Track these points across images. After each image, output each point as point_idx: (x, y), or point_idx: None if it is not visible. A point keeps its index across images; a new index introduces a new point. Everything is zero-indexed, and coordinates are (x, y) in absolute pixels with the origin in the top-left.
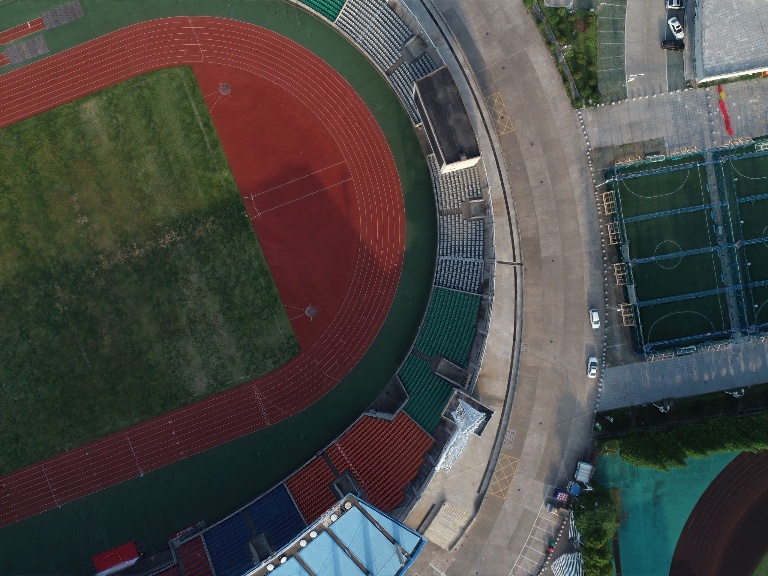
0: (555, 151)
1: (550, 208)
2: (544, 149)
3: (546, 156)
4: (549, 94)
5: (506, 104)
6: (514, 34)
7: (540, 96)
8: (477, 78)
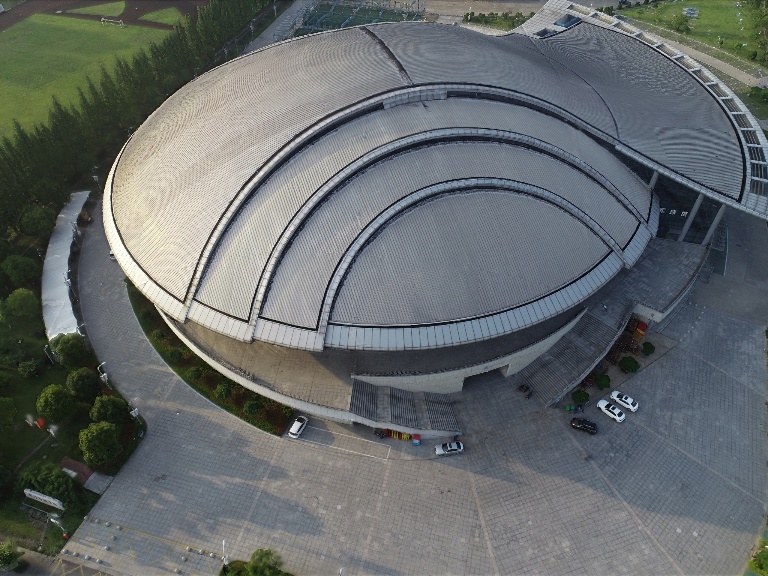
0: (446, 8)
1: (417, 2)
2: (449, 6)
3: (445, 6)
4: (478, 12)
5: (480, 3)
6: (517, 11)
7: (478, 10)
8: (499, 0)
